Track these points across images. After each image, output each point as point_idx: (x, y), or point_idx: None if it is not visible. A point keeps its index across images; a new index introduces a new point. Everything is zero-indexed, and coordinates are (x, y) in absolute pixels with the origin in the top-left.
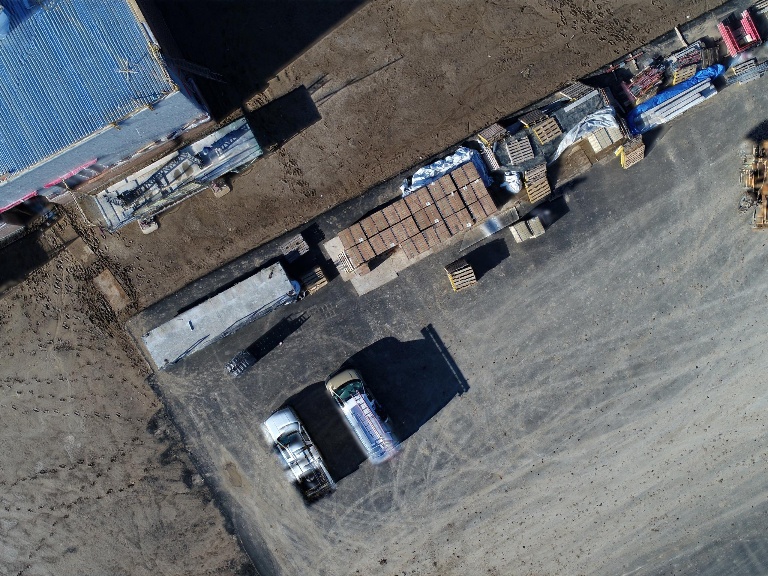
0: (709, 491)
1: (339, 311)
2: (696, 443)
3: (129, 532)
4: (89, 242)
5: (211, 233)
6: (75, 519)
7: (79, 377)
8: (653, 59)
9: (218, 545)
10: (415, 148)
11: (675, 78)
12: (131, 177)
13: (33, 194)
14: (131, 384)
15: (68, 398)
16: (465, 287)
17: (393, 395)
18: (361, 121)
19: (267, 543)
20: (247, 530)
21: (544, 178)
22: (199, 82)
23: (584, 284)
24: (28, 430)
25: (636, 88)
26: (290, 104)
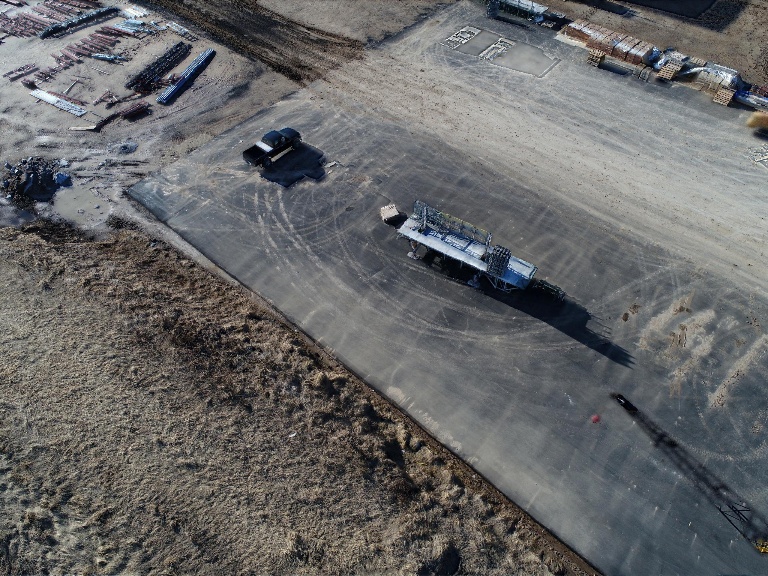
0: (568, 181)
1: None
2: (593, 166)
3: (384, 8)
4: None
5: None
6: None
7: None
8: None
9: None
10: None
11: None
12: None
13: None
14: None
15: None
16: (594, 54)
17: None
18: None
19: None
20: None
21: (674, 70)
22: None
23: (637, 102)
24: None
25: None
26: (618, 7)
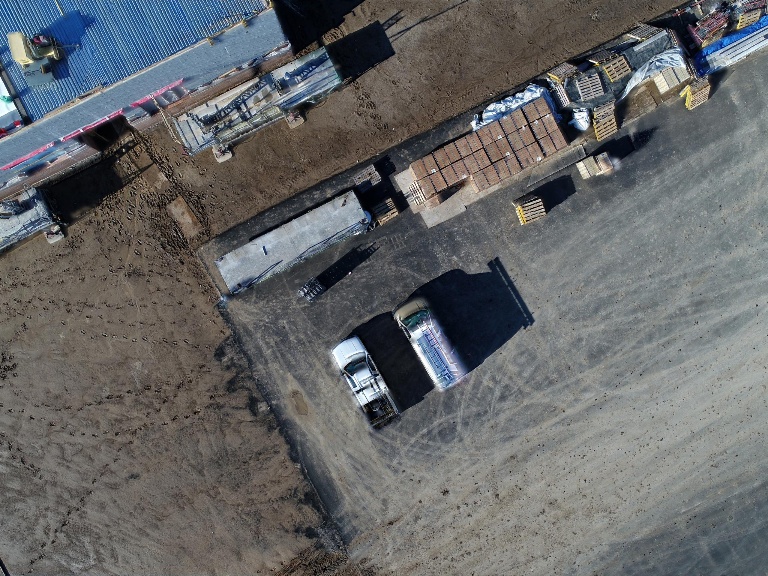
0: (767, 428)
1: (408, 242)
2: (755, 380)
3: (193, 459)
4: (163, 169)
5: (284, 163)
6: (140, 445)
7: (149, 303)
8: (717, 5)
9: (282, 474)
10: (485, 85)
11: (740, 22)
12: (212, 101)
13: (118, 112)
14: (200, 311)
15: (137, 324)
16: (534, 219)
17: (459, 327)
18: (433, 57)
19: (331, 472)
20: (312, 459)
21: (612, 116)
22: (277, 14)
23: (648, 222)
24: (96, 355)
25: (702, 31)
26: (365, 39)
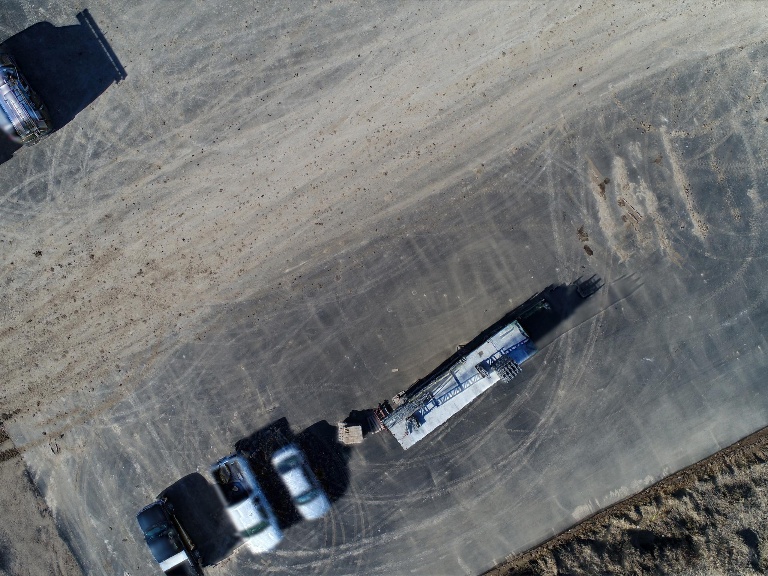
0: (374, 184)
1: None
2: (359, 134)
3: None
4: None
5: None
6: None
7: None
8: None
9: None
10: None
11: None
12: None
13: None
14: None
15: None
16: None
17: (48, 82)
18: None
19: None
20: None
21: None
22: None
23: None
24: None
25: None
26: None
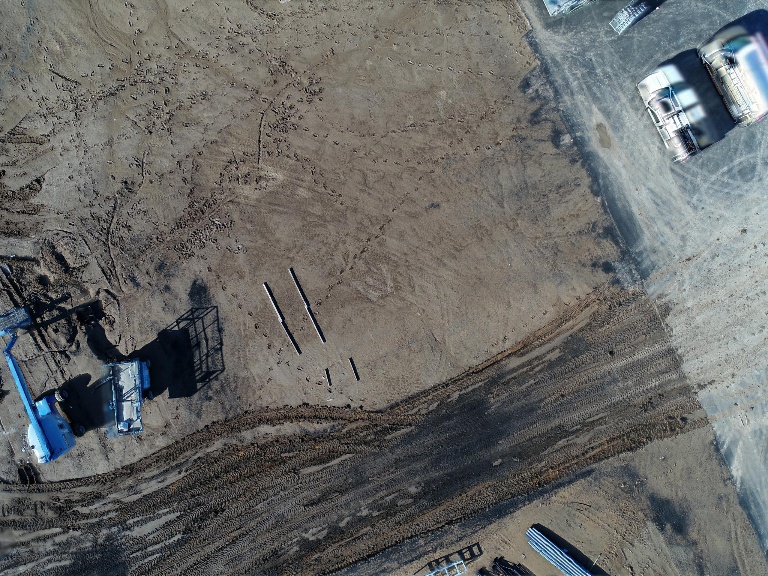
0: None
1: None
2: None
3: (493, 190)
4: None
5: None
6: (441, 174)
7: (456, 32)
8: None
9: (581, 207)
10: None
11: None
12: None
13: None
14: (507, 42)
15: (443, 53)
16: None
17: (762, 67)
18: None
19: (631, 206)
20: (613, 192)
21: None
22: None
23: None
24: (401, 82)
25: None
26: None
